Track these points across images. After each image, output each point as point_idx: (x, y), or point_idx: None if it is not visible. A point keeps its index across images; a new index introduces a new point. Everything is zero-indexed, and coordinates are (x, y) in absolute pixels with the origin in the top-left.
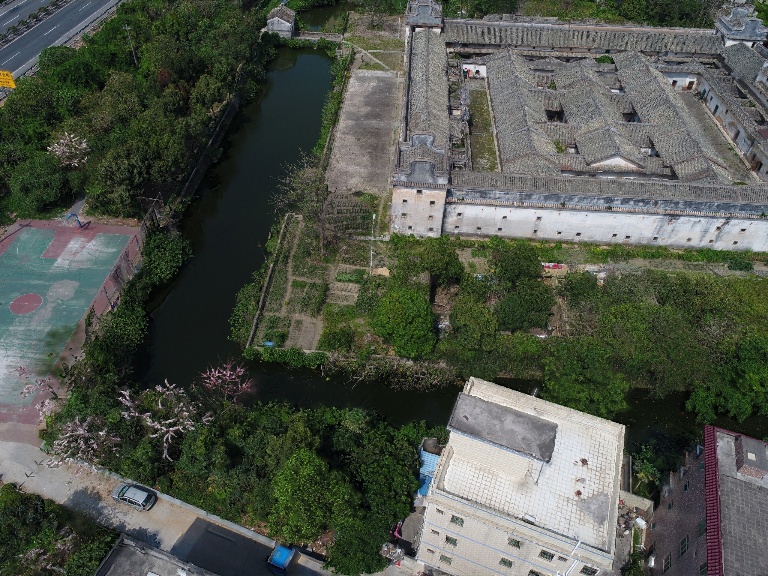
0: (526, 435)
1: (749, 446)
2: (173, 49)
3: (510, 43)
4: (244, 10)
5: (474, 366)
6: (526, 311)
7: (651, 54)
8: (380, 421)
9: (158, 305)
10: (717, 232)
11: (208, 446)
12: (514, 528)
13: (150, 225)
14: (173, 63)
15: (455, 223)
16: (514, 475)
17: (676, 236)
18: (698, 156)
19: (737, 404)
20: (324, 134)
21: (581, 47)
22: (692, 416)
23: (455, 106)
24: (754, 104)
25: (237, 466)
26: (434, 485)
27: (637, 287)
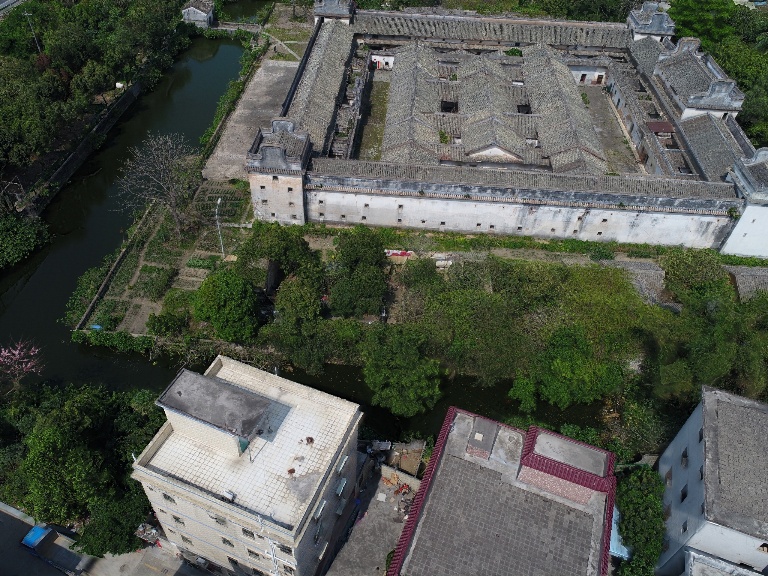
0: (234, 411)
1: (480, 426)
2: (74, 36)
3: (419, 35)
4: (168, 0)
5: (300, 351)
6: (356, 297)
7: (561, 47)
8: None
9: (6, 289)
10: (579, 222)
11: None
12: (210, 505)
13: (2, 208)
14: (61, 49)
15: (319, 211)
16: (231, 453)
17: (540, 226)
18: (574, 147)
19: (554, 392)
20: (216, 122)
21: (490, 39)
22: (517, 404)
23: (351, 96)
24: (650, 97)
25: (8, 446)
26: (136, 461)
27: (473, 274)
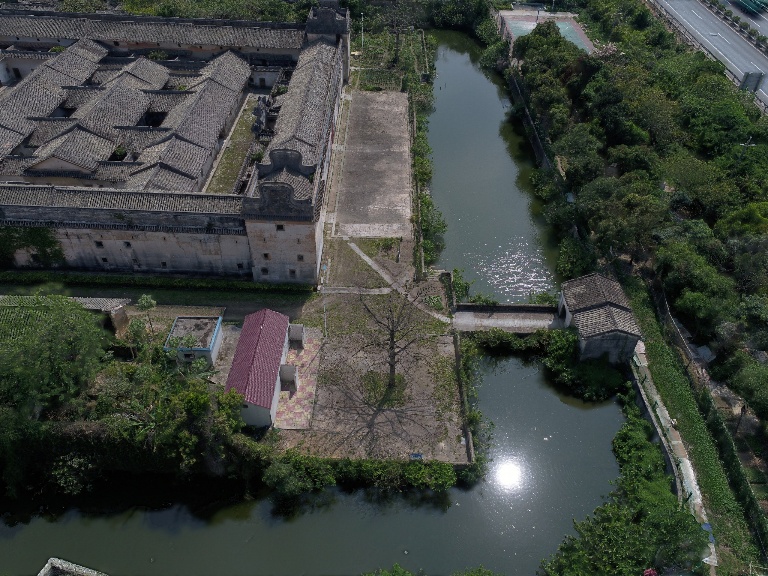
0: None
1: None
2: None
3: None
4: (766, 441)
5: None
6: None
7: None
8: None
9: None
10: None
11: None
12: None
13: None
14: None
15: None
16: None
17: None
18: None
19: None
20: None
21: None
22: None
23: None
24: None
25: None
26: None
27: None
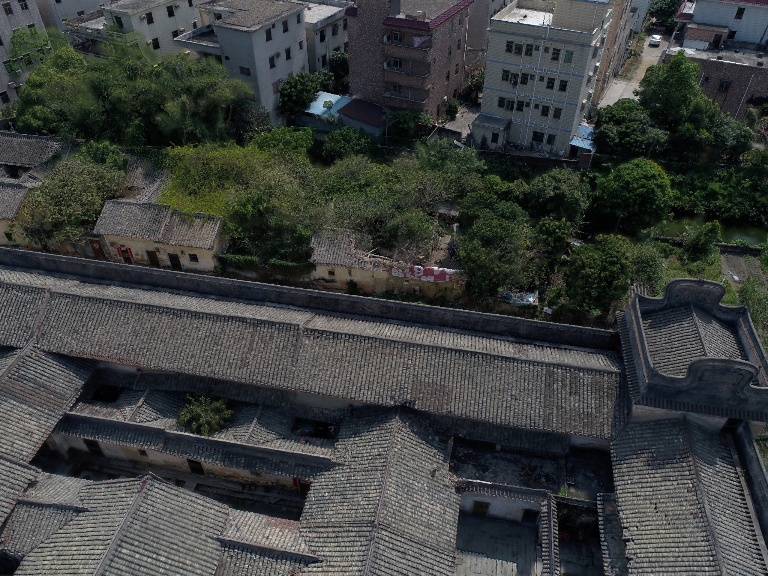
0: None
1: None
2: None
3: None
4: None
5: None
6: None
7: None
8: None
9: None
10: None
11: (763, 122)
12: None
13: None
14: None
15: None
16: None
17: None
18: None
19: None
20: None
21: None
22: None
23: None
24: None
25: None
26: None
27: None
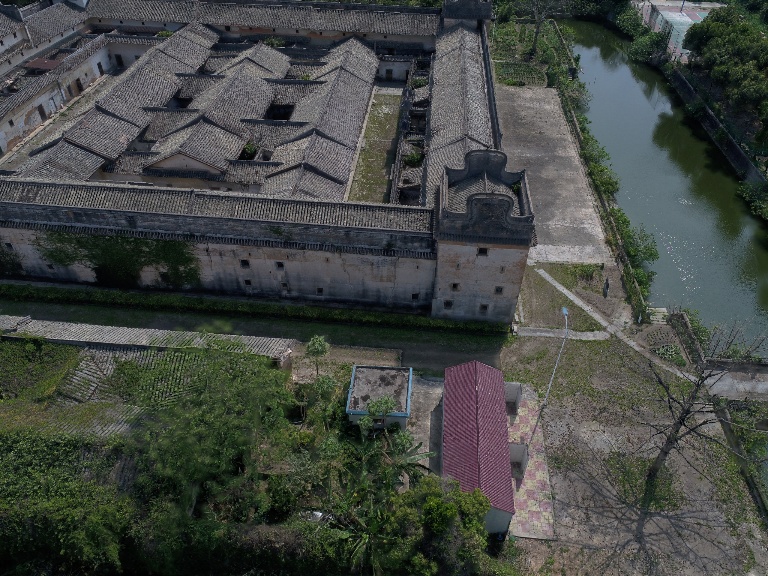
0: None
1: None
2: None
3: None
4: None
5: None
6: None
7: None
8: None
9: None
10: None
11: None
12: None
13: None
14: None
15: None
16: None
17: None
18: None
19: None
20: None
21: None
22: None
23: None
24: None
25: None
26: None
27: None
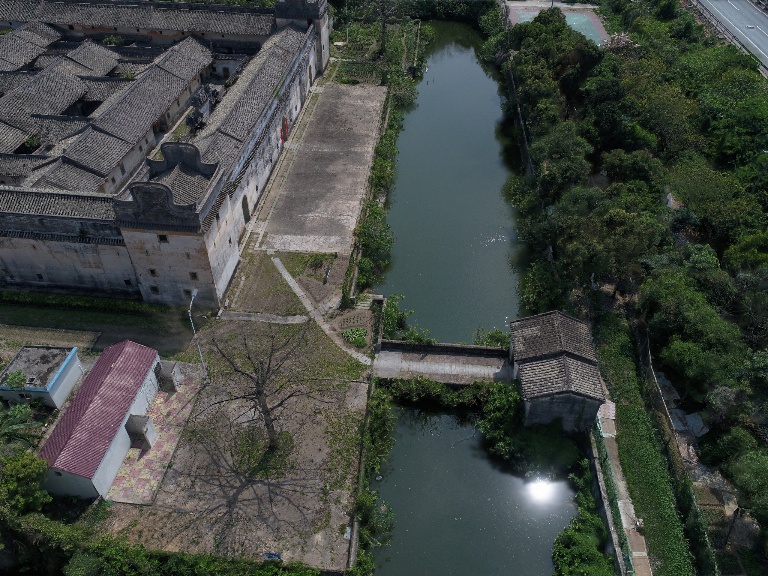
0: None
1: None
2: None
3: None
4: None
5: None
6: None
7: None
8: (350, 1)
9: None
10: None
11: None
12: None
13: None
14: None
15: None
16: None
17: None
18: None
19: None
20: None
21: None
22: None
23: None
24: None
25: None
26: None
27: None
